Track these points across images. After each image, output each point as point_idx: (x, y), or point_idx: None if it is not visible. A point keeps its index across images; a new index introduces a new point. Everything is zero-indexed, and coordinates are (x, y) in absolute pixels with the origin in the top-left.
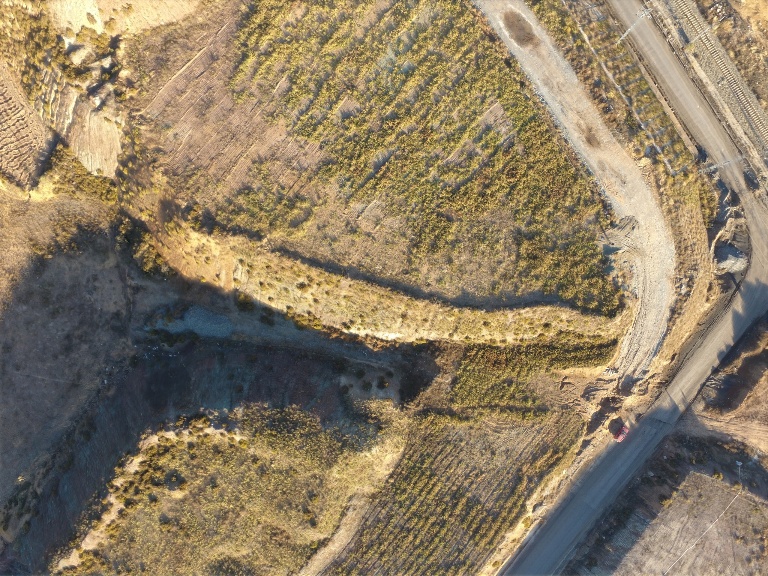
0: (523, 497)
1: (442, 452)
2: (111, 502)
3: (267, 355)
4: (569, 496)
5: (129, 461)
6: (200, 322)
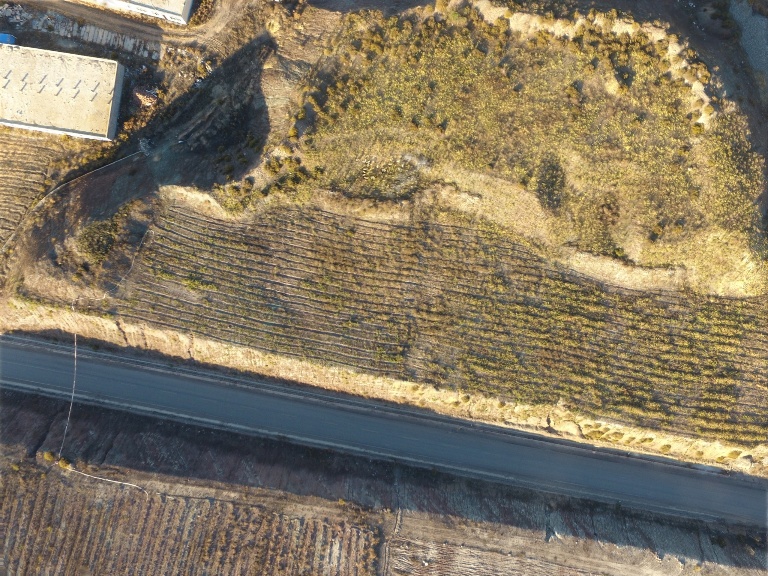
0: (766, 438)
1: (767, 335)
2: (577, 22)
3: (761, 116)
4: (766, 486)
5: (627, 20)
6: (763, 32)
